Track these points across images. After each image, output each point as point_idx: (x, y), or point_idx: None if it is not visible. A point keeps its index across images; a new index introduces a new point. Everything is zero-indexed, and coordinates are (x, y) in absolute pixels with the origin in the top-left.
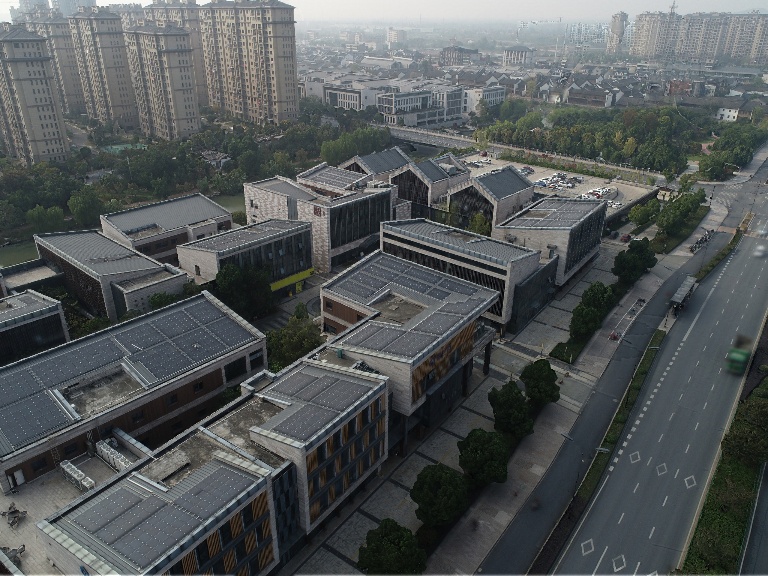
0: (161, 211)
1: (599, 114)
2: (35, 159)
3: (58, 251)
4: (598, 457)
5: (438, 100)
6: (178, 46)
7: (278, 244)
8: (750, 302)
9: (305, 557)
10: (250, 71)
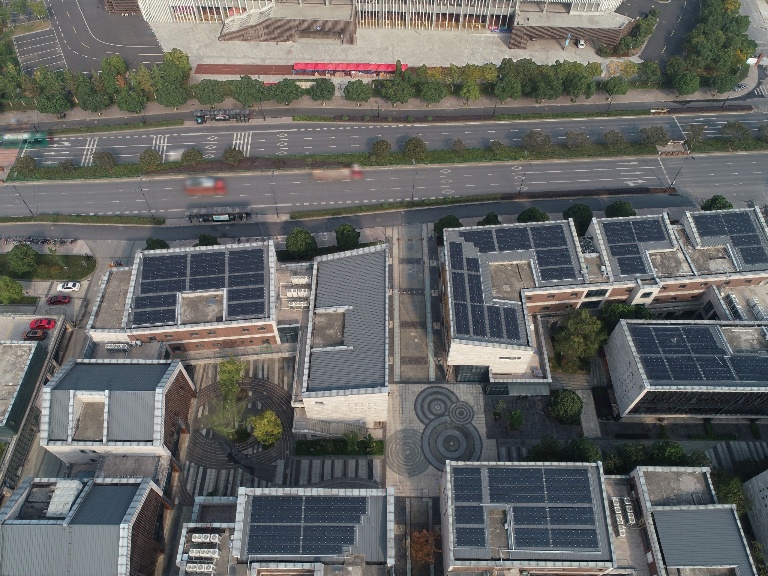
0: None
1: None
2: None
3: None
4: (468, 200)
5: None
6: None
7: None
8: (186, 187)
9: None
10: None
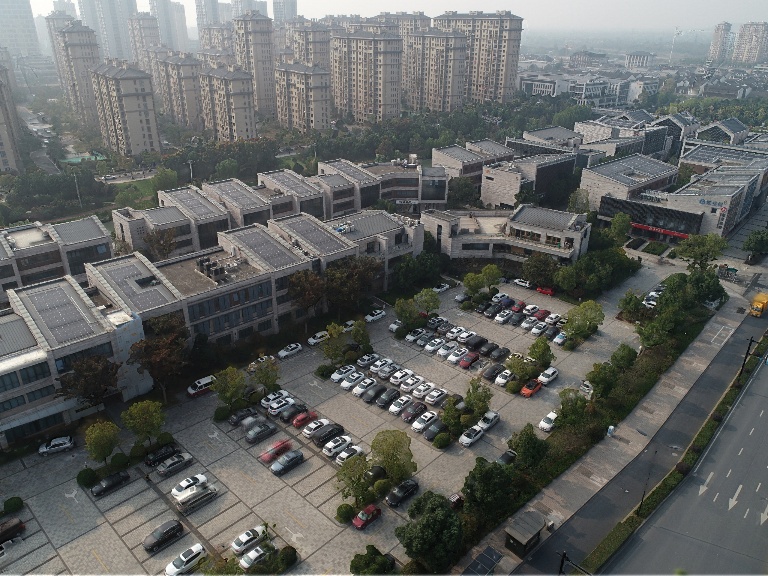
0: (548, 132)
1: (743, 101)
2: (383, 117)
3: (532, 142)
4: None
5: (612, 90)
6: (461, 45)
7: (632, 145)
8: None
9: (733, 235)
10: (479, 65)
